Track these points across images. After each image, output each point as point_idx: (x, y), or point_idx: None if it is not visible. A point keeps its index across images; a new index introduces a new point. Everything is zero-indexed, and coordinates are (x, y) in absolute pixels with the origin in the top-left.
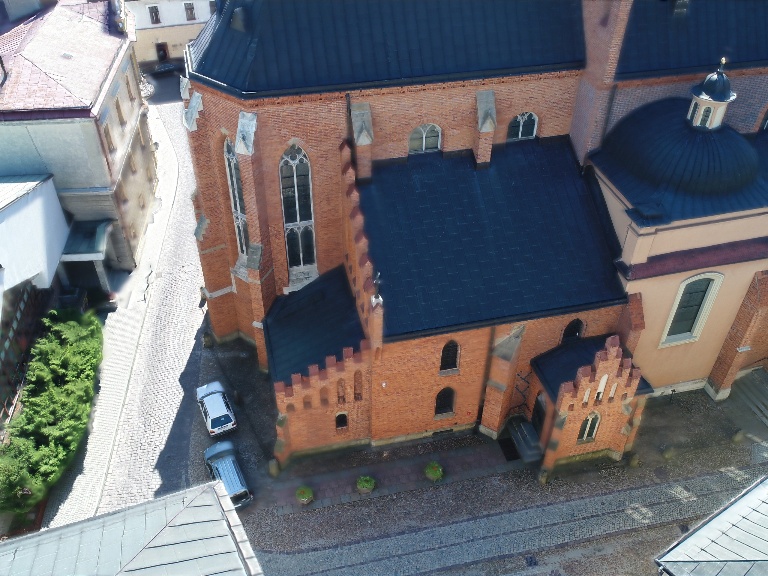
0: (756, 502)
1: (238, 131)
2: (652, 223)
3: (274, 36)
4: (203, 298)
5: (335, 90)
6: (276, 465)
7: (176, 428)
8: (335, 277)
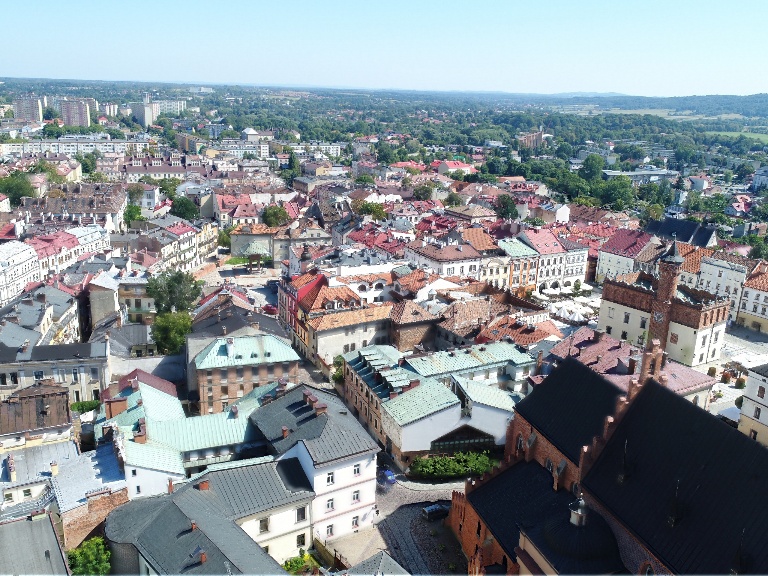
0: (408, 575)
1: None
2: (520, 526)
3: None
4: None
5: None
6: (443, 522)
7: None
8: None
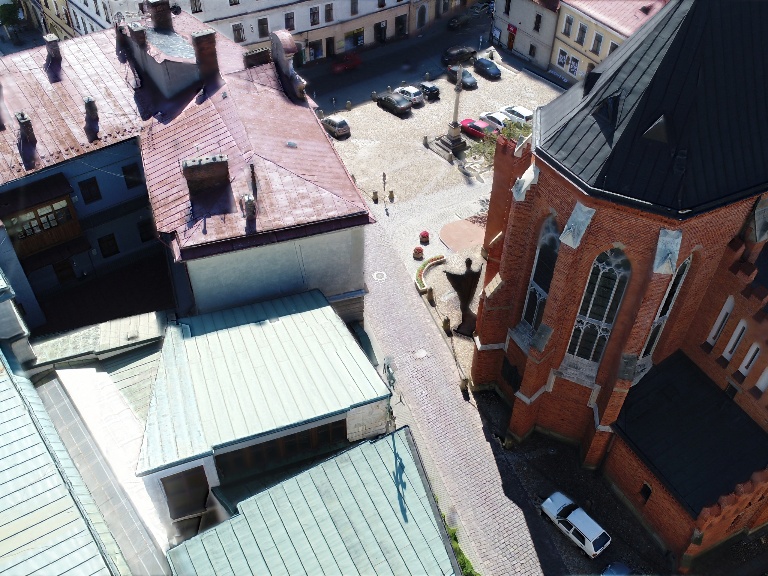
0: None
1: (659, 250)
2: None
3: (700, 144)
4: (464, 389)
5: (755, 193)
6: None
7: (542, 554)
8: (675, 366)
